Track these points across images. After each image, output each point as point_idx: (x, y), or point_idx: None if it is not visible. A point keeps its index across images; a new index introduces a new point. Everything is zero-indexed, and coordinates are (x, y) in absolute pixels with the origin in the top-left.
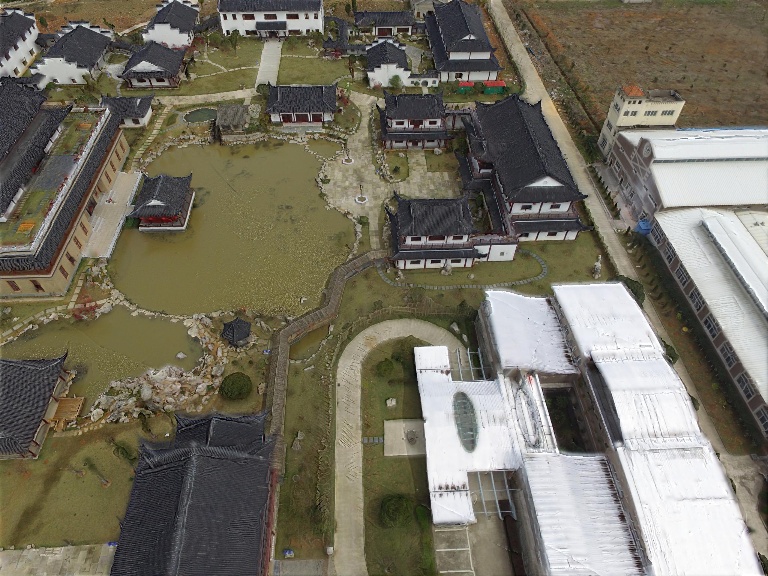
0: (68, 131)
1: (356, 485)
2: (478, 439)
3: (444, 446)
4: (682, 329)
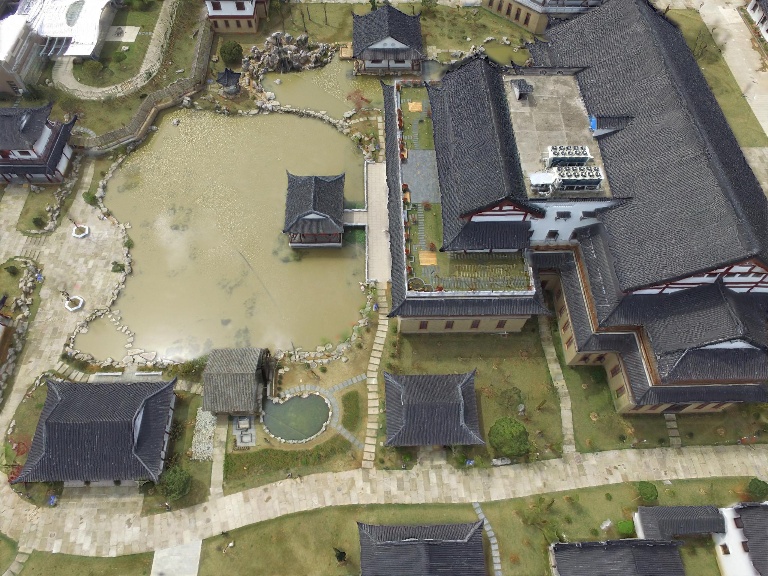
0: None
1: (163, 16)
2: (73, 2)
3: (96, 2)
4: None
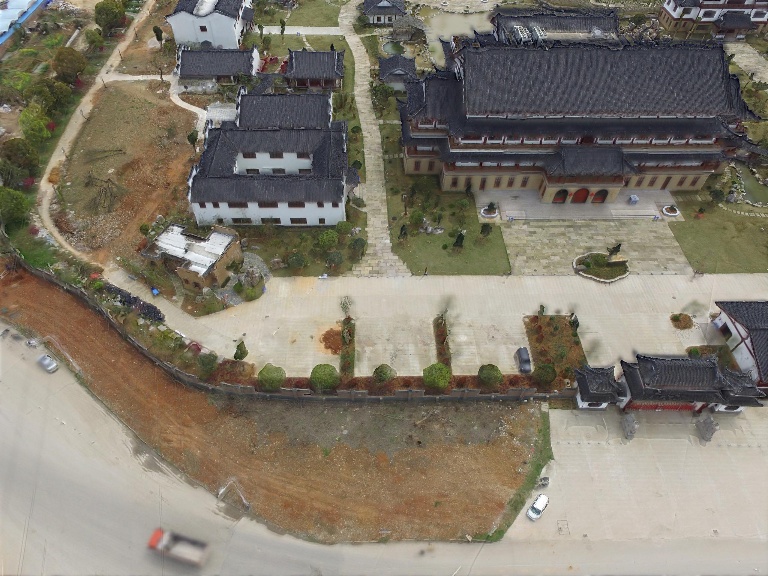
0: None
1: None
2: None
3: None
4: None
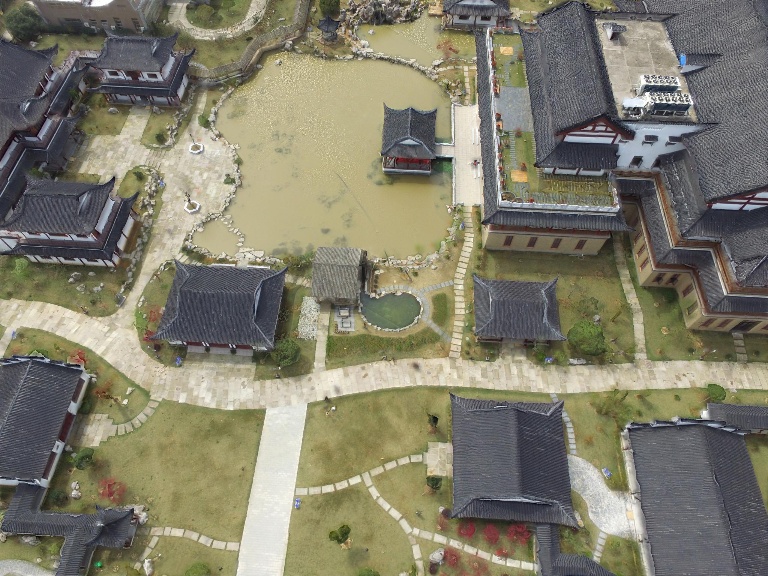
0: (537, 171)
1: None
2: None
3: None
4: (3, 14)
